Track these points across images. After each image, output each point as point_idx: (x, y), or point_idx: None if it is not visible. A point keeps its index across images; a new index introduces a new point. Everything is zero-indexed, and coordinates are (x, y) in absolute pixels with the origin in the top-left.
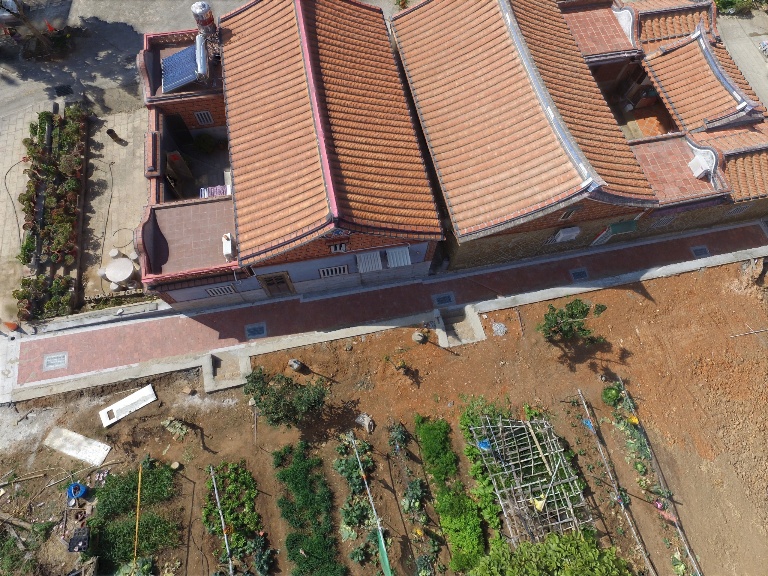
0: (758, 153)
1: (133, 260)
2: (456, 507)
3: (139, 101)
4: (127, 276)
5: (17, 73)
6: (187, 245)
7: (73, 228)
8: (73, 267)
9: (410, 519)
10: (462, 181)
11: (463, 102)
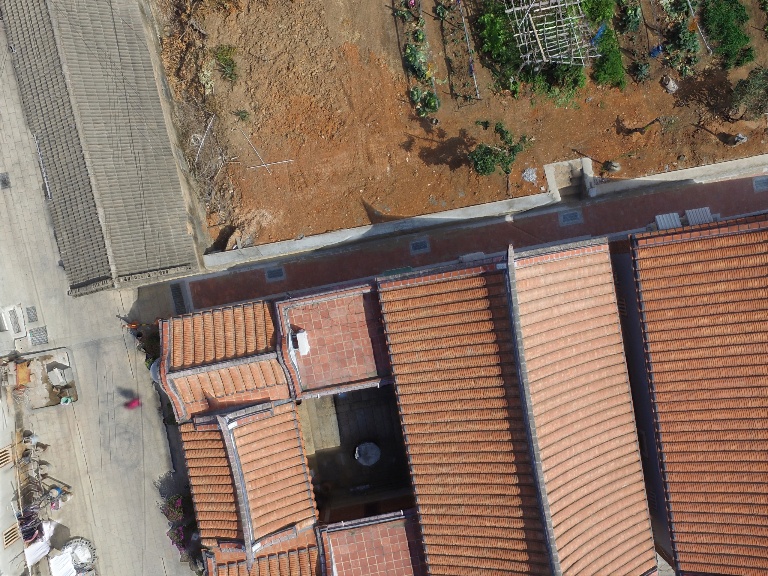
0: (227, 359)
1: None
2: (604, 2)
3: None
4: None
5: None
6: None
7: None
8: None
9: (635, 1)
10: (600, 312)
11: (593, 421)
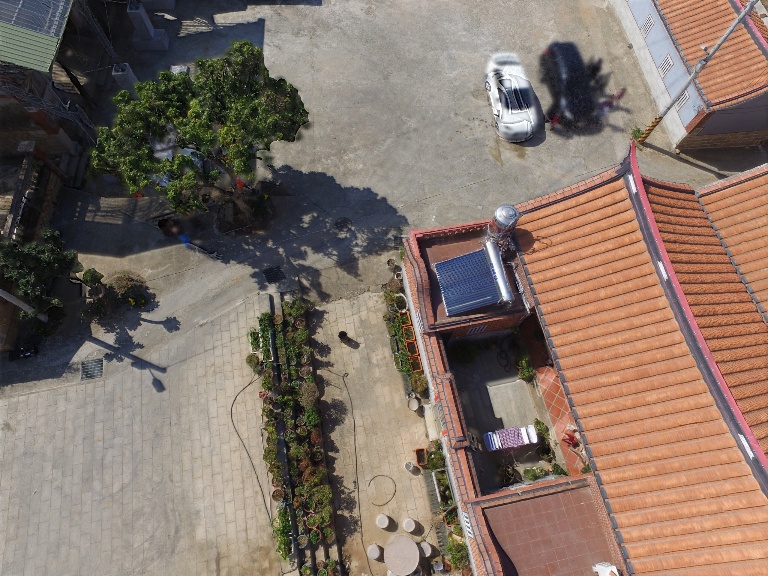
0: None
1: (408, 531)
2: None
3: (361, 283)
4: (415, 567)
5: (216, 253)
6: (542, 570)
7: (321, 481)
8: (332, 543)
9: None
10: None
11: None
